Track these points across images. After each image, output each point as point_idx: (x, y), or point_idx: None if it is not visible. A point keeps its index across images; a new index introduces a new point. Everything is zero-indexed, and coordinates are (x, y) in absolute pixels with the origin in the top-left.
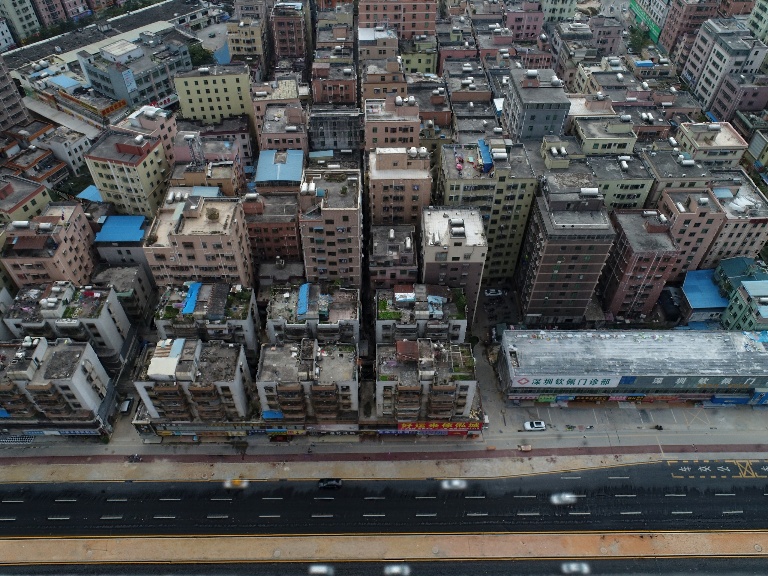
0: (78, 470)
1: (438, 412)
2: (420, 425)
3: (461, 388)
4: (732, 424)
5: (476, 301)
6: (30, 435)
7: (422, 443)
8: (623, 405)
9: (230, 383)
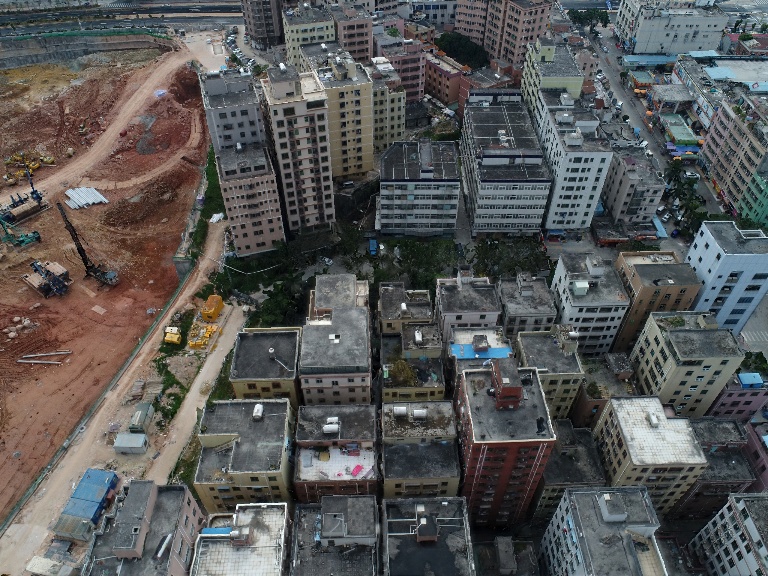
0: (239, 3)
1: None
2: None
3: None
4: None
5: None
6: None
7: None
8: None
9: None
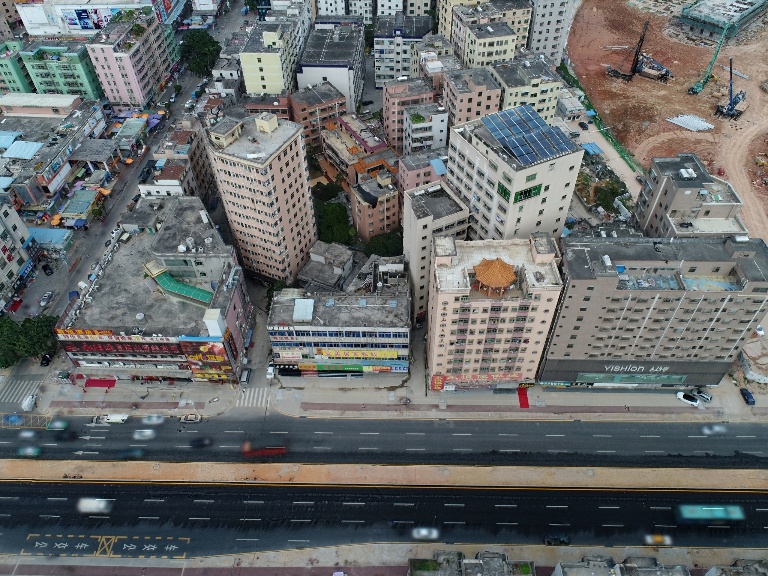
0: None
1: None
2: None
3: None
4: None
5: None
6: None
7: None
8: None
9: (719, 567)
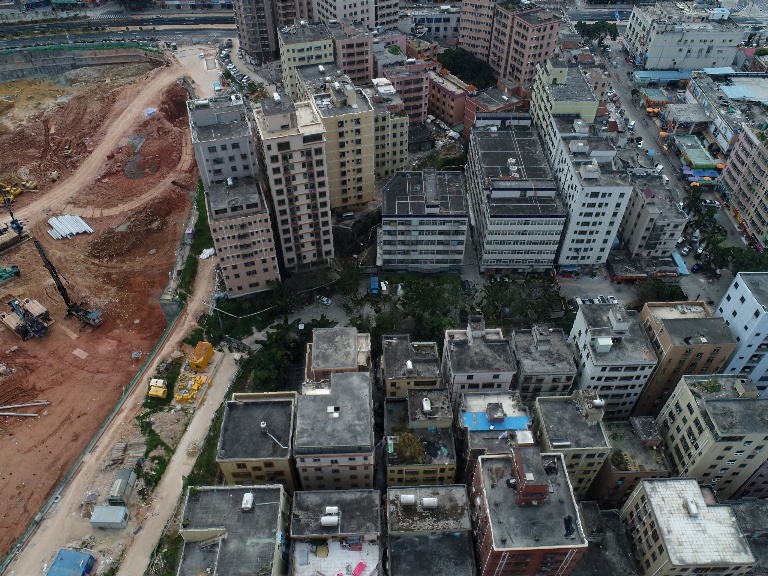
0: (233, 14)
1: None
2: None
3: None
4: None
5: None
6: (211, 7)
7: None
8: (456, 3)
9: None
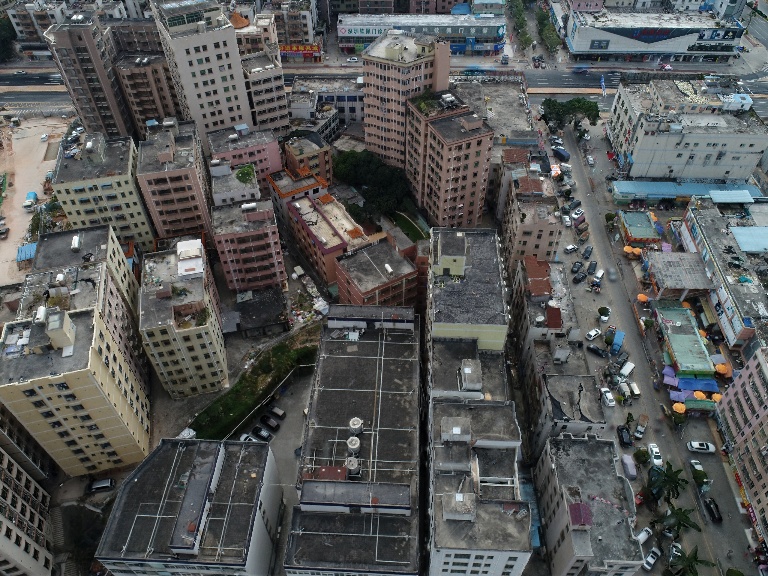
0: None
1: (294, 35)
2: (288, 48)
3: (303, 17)
4: (458, 61)
5: (328, 4)
6: None
7: (291, 64)
8: None
9: None
